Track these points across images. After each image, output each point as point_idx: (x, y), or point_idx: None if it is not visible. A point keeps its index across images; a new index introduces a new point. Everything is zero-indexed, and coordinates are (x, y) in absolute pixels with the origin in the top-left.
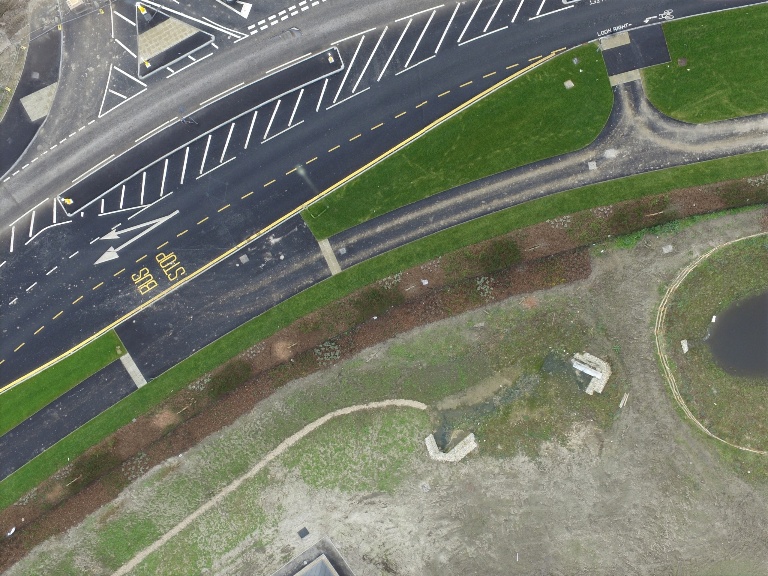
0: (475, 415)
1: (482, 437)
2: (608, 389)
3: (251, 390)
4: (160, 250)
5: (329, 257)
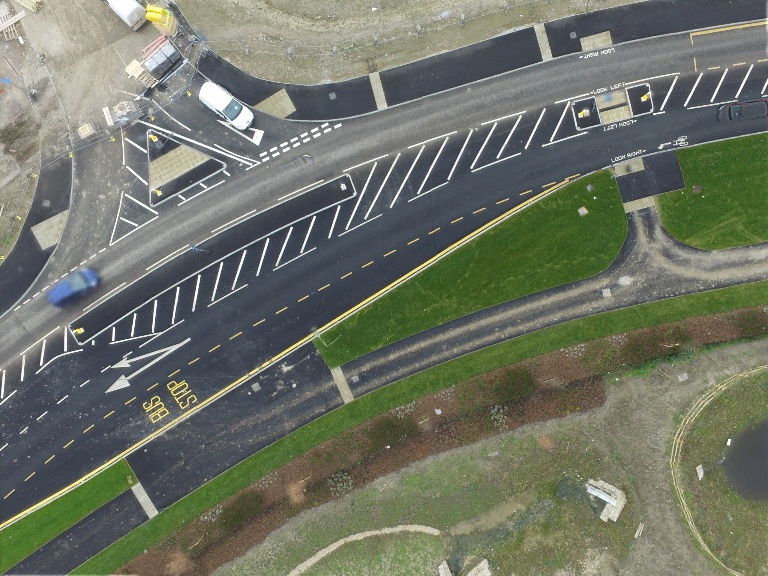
0: (489, 541)
1: (496, 564)
2: (623, 518)
3: (263, 520)
4: (171, 378)
5: (342, 385)
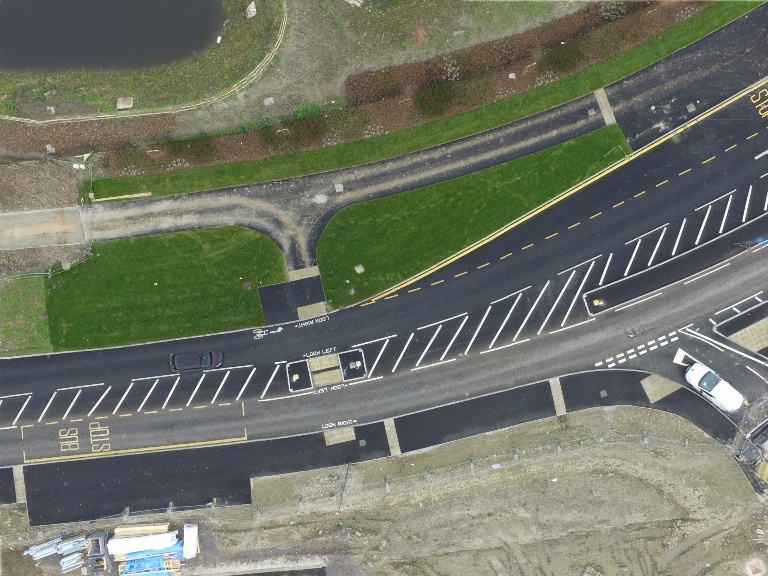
0: None
1: None
2: None
3: None
4: None
5: (606, 106)
